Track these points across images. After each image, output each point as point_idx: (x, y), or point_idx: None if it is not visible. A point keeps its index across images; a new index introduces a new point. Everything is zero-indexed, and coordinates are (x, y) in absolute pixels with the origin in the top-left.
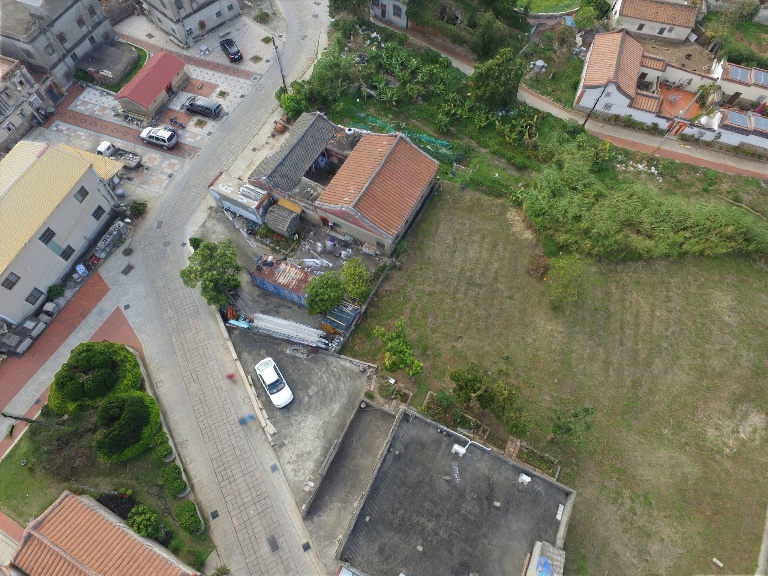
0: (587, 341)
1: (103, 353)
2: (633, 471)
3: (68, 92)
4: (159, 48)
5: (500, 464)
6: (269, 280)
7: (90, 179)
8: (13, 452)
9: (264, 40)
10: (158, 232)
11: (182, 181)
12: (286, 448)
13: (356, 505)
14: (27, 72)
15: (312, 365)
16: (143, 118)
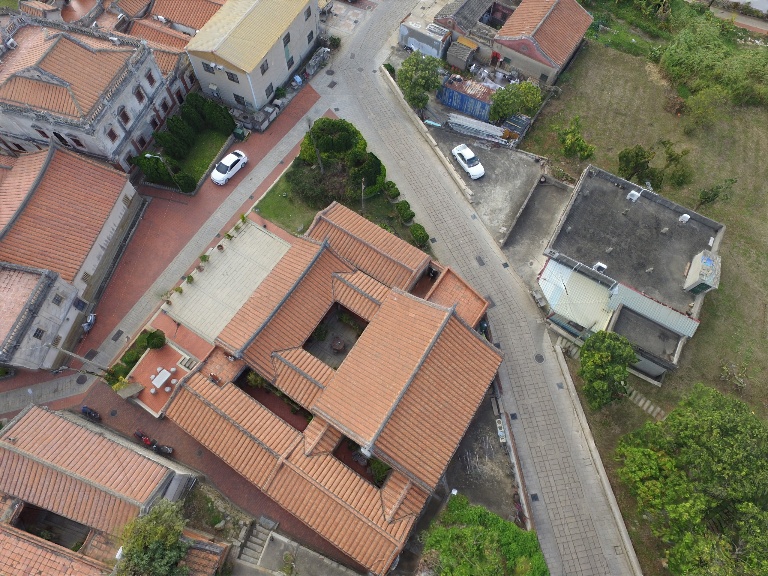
0: (716, 157)
1: None
2: (758, 239)
3: None
4: None
5: (664, 209)
6: (459, 91)
7: (314, 2)
8: (274, 188)
9: None
10: (352, 61)
11: (366, 26)
12: (482, 205)
13: (557, 223)
14: None
15: (496, 155)
16: None
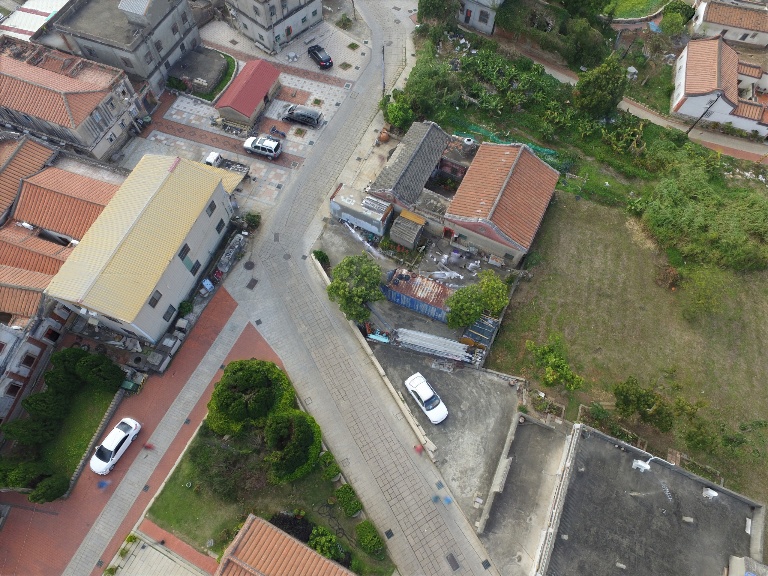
0: (726, 351)
1: (258, 372)
2: None
3: (161, 101)
4: (245, 55)
5: (682, 479)
6: (408, 294)
7: (218, 193)
8: (176, 474)
9: (351, 46)
10: (276, 245)
11: (292, 192)
12: (448, 465)
13: (548, 523)
14: (129, 81)
15: (460, 380)
16: (244, 127)
